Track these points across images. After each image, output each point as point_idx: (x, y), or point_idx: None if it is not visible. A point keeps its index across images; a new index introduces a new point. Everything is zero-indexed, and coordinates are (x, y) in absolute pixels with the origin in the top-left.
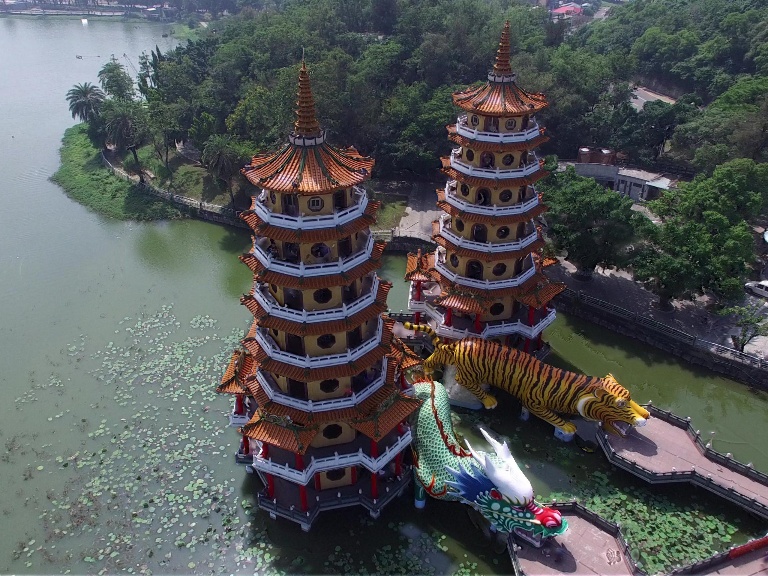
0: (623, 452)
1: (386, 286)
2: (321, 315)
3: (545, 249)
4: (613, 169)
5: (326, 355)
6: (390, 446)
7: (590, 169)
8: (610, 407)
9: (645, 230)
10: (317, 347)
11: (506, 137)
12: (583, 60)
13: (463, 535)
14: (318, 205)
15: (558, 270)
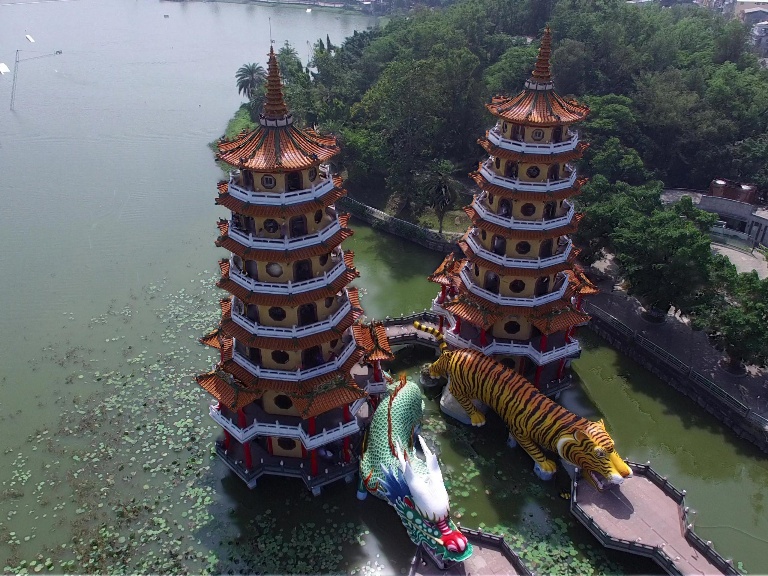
0: (590, 506)
1: (351, 274)
2: (268, 287)
3: (626, 281)
4: (747, 208)
5: None
6: (329, 429)
7: (719, 204)
8: (588, 454)
9: (717, 276)
10: (269, 317)
11: (529, 147)
12: (750, 82)
13: (398, 539)
14: (271, 183)
15: (629, 305)
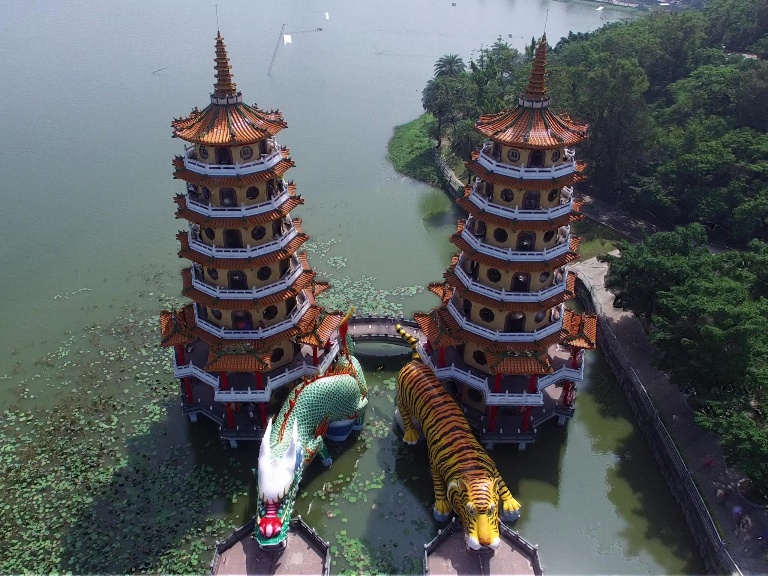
0: (445, 560)
1: (283, 255)
2: (200, 246)
3: None
4: None
5: (206, 283)
6: (238, 389)
7: None
8: (463, 507)
9: (748, 373)
10: (208, 275)
11: (499, 167)
12: None
13: None
14: None
15: None
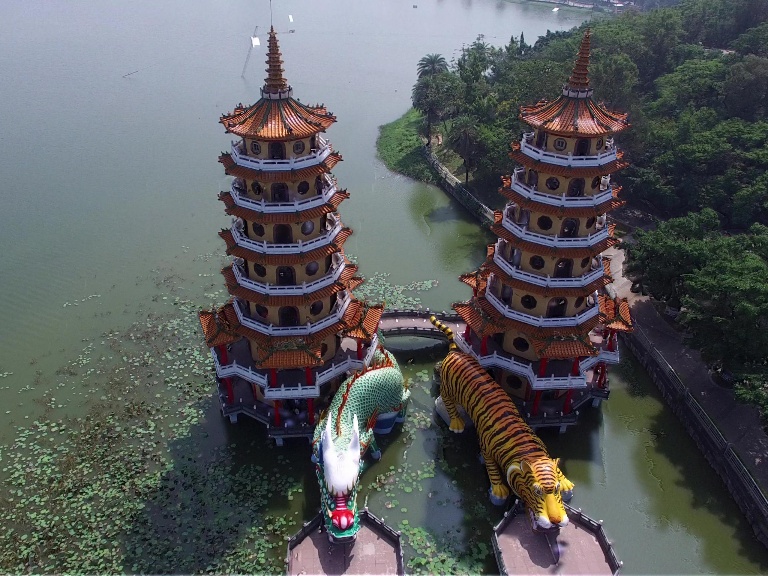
0: (514, 541)
1: (333, 249)
2: (249, 243)
3: None
4: None
5: None
6: (288, 386)
7: None
8: (528, 488)
9: None
10: (254, 272)
11: (546, 156)
12: None
13: None
14: (258, 149)
15: None
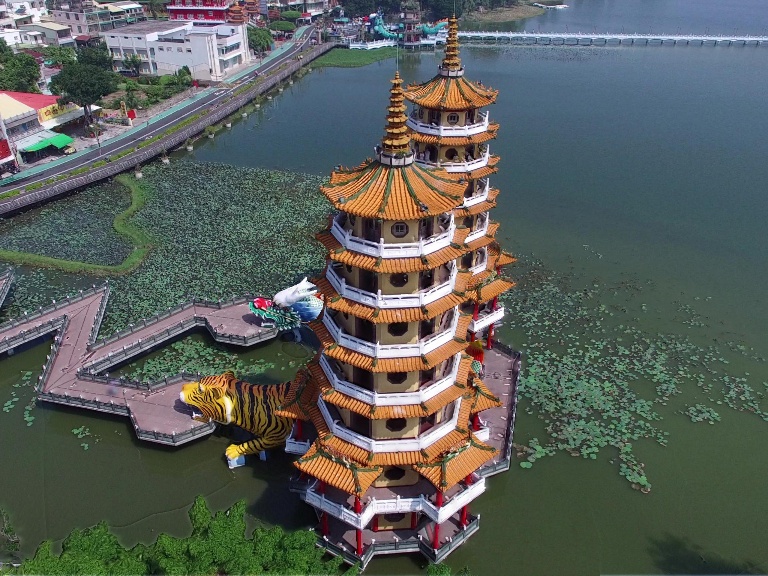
0: None
1: None
2: None
3: None
4: None
5: None
6: None
7: None
8: None
9: None
10: None
11: None
12: None
13: None
14: None
15: None
